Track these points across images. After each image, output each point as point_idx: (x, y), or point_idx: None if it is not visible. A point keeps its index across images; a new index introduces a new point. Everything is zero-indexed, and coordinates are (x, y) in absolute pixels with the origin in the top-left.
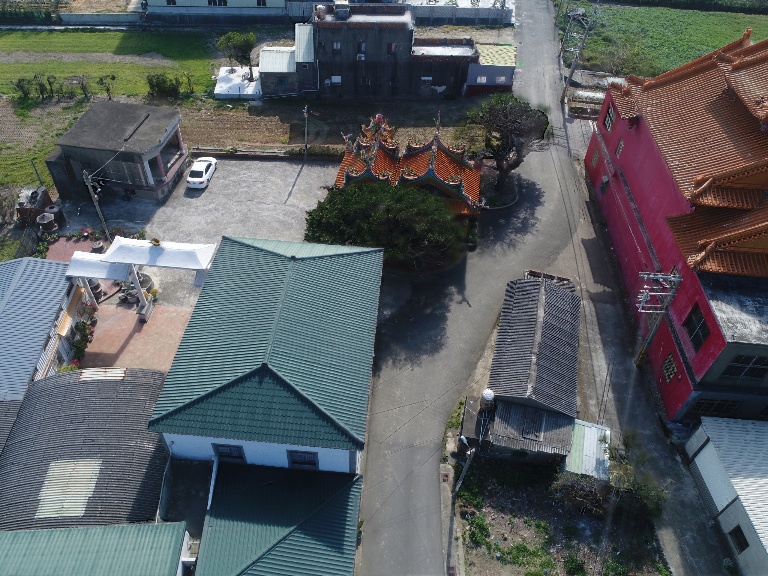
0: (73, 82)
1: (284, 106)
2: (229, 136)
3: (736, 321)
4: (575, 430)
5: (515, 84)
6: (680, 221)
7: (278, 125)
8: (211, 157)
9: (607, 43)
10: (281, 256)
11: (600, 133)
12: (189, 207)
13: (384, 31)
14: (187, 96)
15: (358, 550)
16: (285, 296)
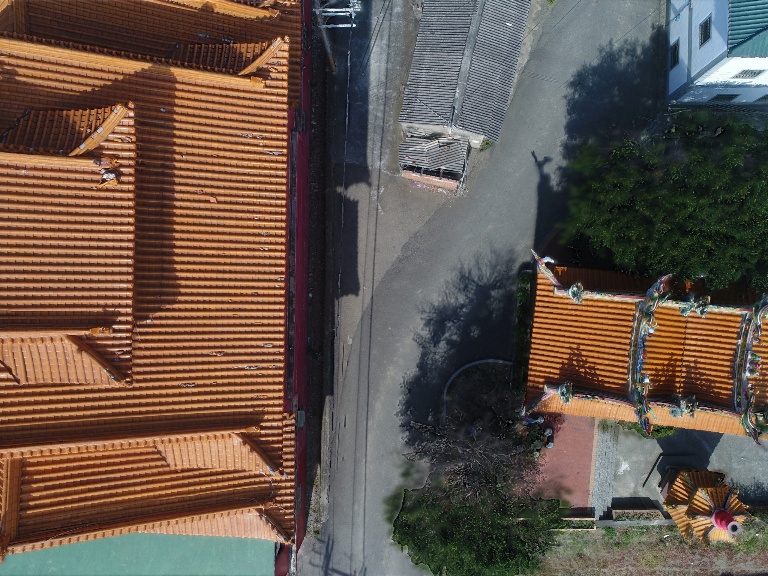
0: None
1: None
2: None
3: None
4: None
5: None
6: None
7: None
8: None
9: None
10: None
11: None
12: None
13: None
14: None
15: None
16: None
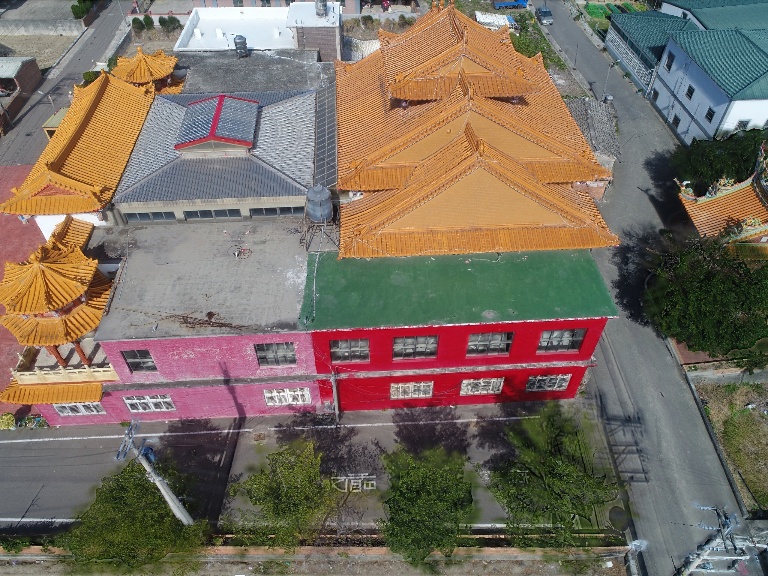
0: None
1: None
2: None
3: None
4: None
5: None
6: None
7: None
8: None
9: None
10: None
11: None
12: None
13: None
14: None
15: None
16: (760, 49)
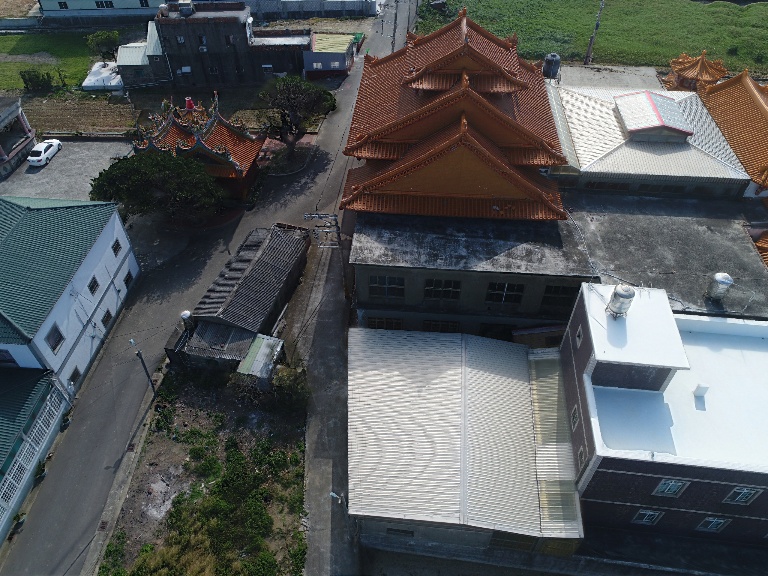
0: None
1: (142, 95)
2: (84, 122)
3: (366, 248)
4: (255, 342)
5: (354, 69)
6: (355, 172)
7: (131, 111)
8: None
9: None
10: (22, 208)
11: None
12: (26, 181)
13: (219, 25)
14: (58, 89)
15: (63, 433)
16: (8, 236)
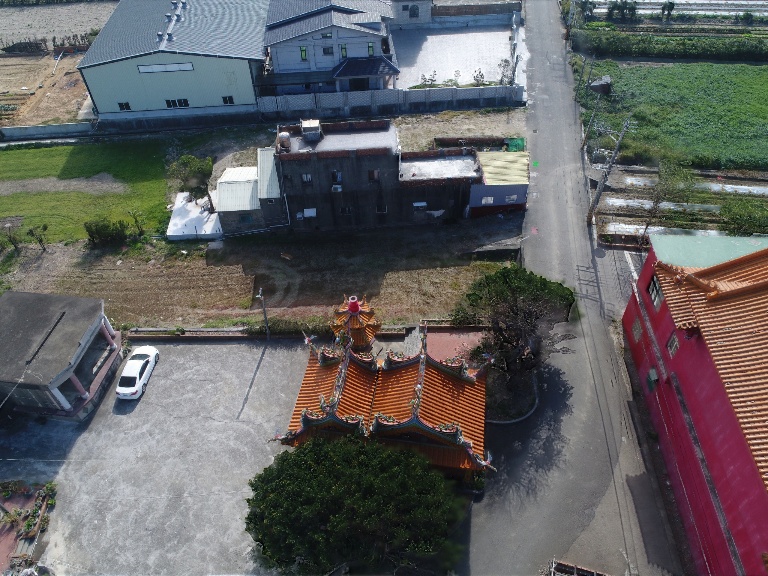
0: (6, 225)
1: (249, 247)
2: (179, 301)
3: None
4: None
5: (529, 197)
6: None
7: (240, 278)
8: (151, 346)
9: (639, 122)
10: None
11: (642, 302)
12: (117, 431)
13: (363, 158)
14: (134, 241)
15: None
16: None
